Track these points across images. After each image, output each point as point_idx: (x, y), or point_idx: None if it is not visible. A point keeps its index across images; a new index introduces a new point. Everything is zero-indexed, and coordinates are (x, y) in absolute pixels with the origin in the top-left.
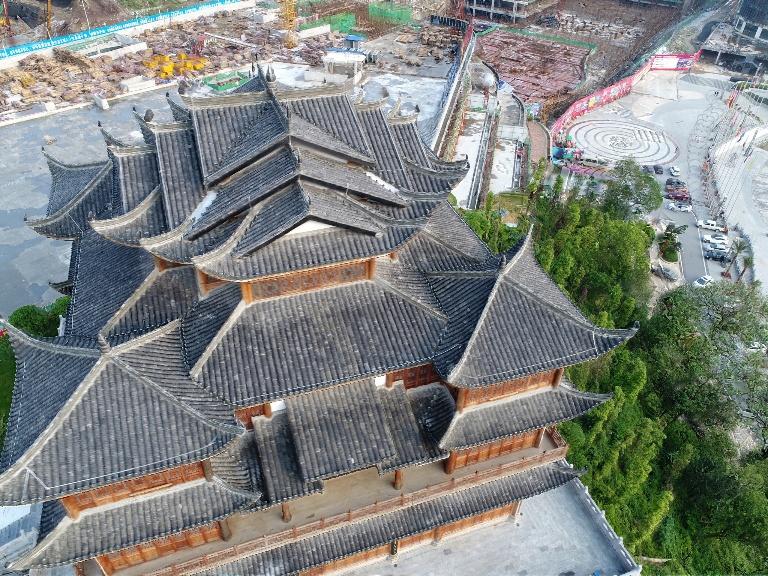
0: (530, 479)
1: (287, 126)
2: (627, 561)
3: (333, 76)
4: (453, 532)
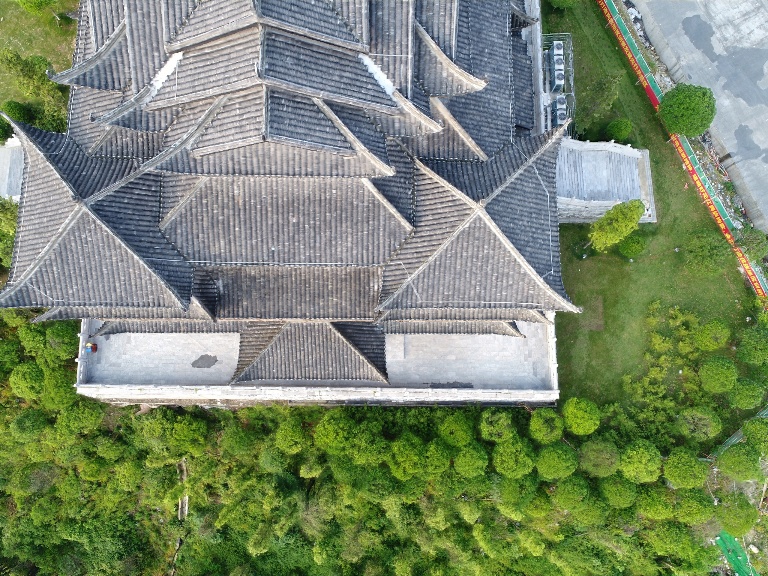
0: None
1: None
2: None
3: None
4: None
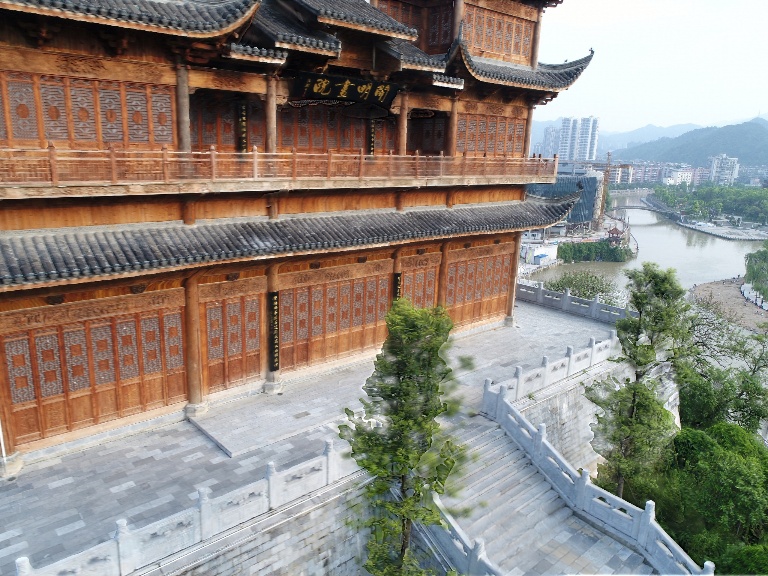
0: (528, 213)
1: None
2: None
3: None
4: (454, 328)
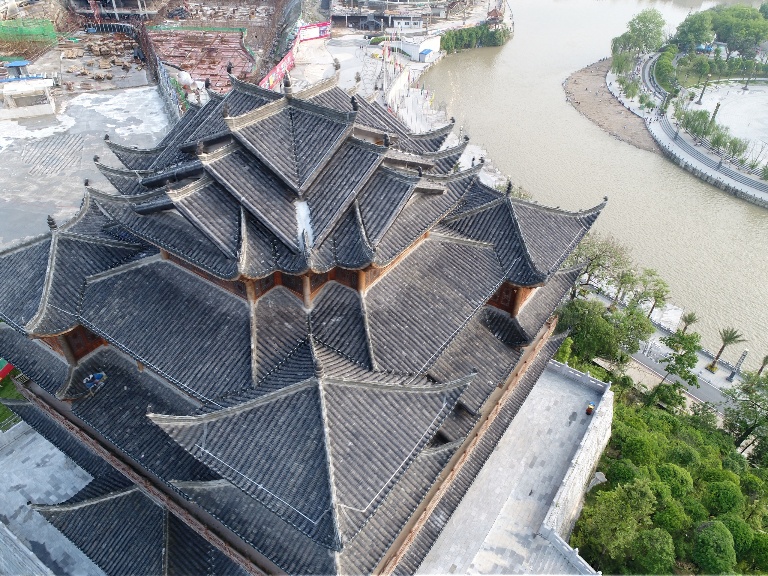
0: (538, 356)
1: (350, 119)
2: (598, 385)
3: (23, 110)
4: None
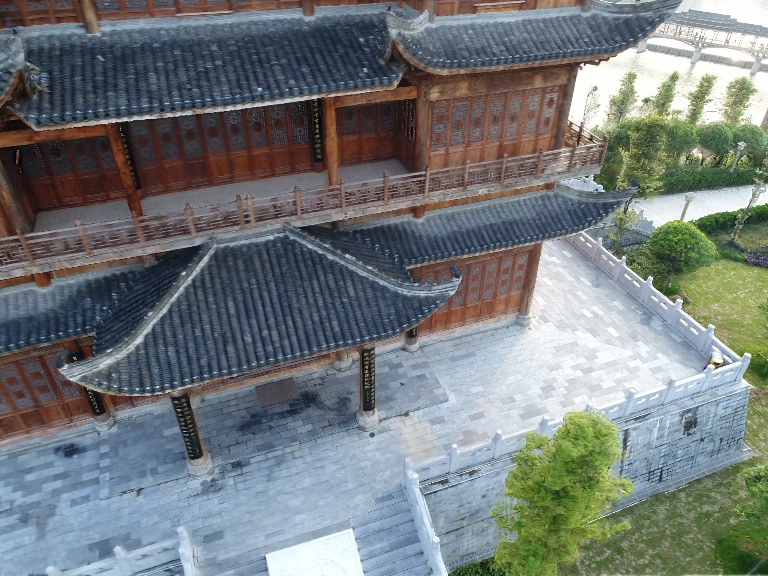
0: None
1: None
2: None
3: None
4: None
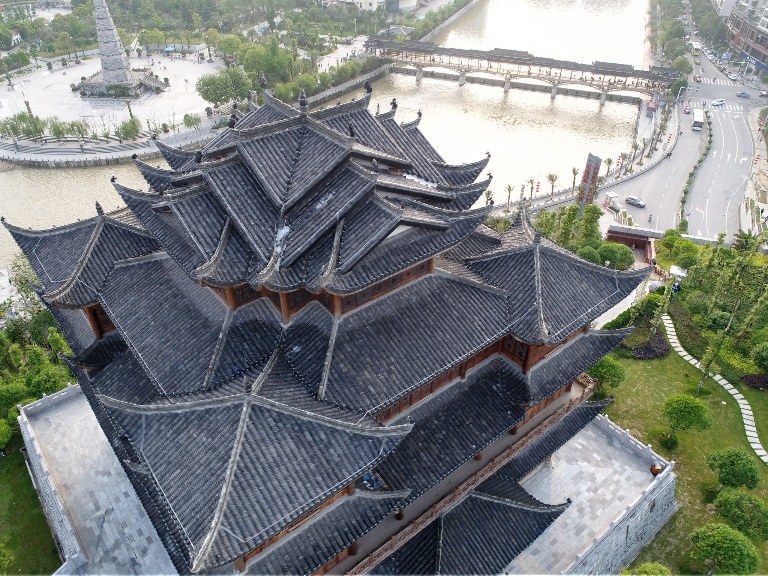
0: None
1: (366, 103)
2: None
3: None
4: None
